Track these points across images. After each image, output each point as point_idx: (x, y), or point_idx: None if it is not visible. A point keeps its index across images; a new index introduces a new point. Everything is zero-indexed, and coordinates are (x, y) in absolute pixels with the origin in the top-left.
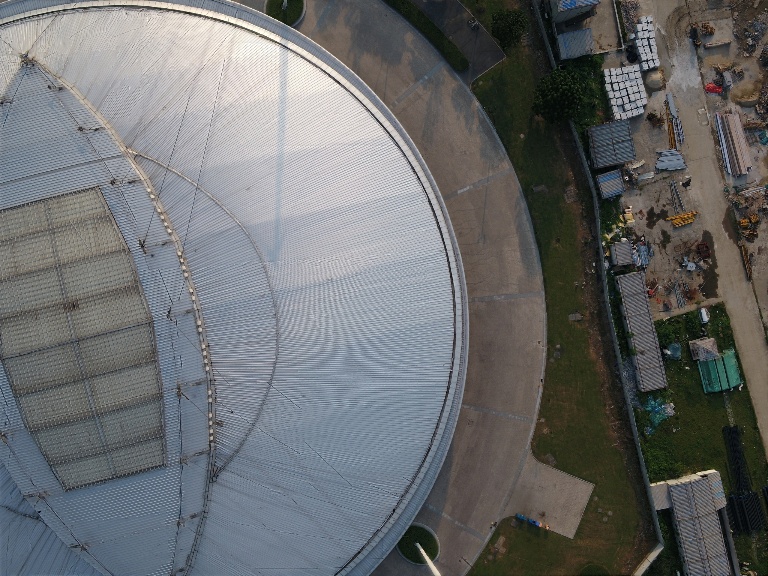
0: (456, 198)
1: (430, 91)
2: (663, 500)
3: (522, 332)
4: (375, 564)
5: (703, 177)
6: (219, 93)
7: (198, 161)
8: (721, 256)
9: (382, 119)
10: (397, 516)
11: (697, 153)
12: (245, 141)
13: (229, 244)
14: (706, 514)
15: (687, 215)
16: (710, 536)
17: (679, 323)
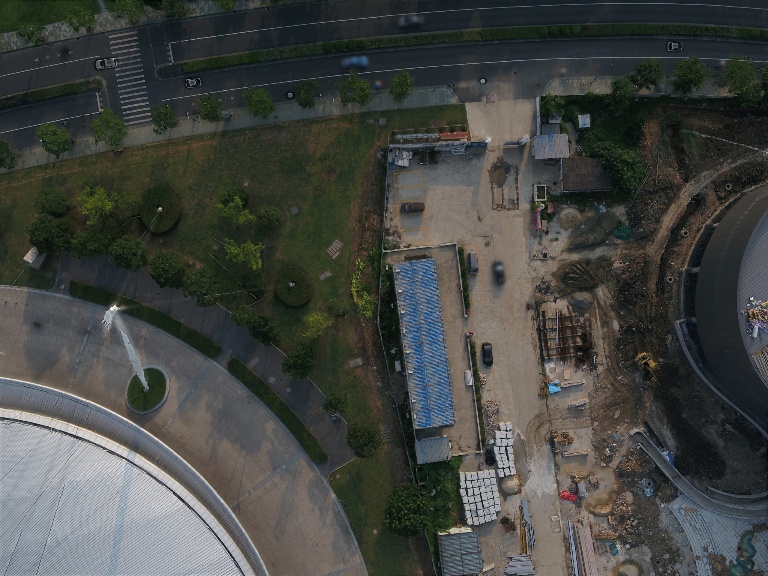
0: None
1: (287, 481)
2: None
3: None
4: None
5: None
6: (53, 526)
7: None
8: None
9: (224, 538)
10: None
11: (547, 559)
12: None
13: None
14: None
15: None
16: None
17: None
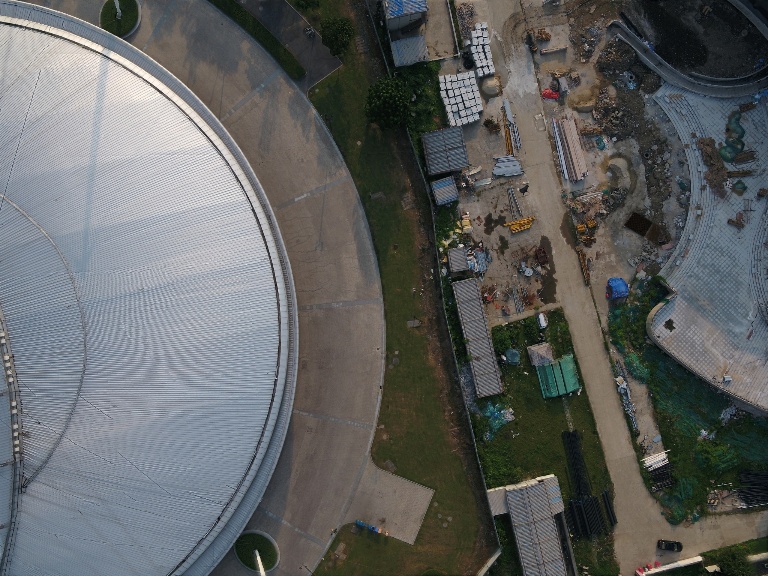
0: (293, 206)
1: (267, 99)
2: (500, 505)
3: (361, 339)
4: (206, 572)
5: (540, 183)
6: (32, 104)
7: (6, 172)
8: (559, 261)
9: (205, 128)
10: (223, 524)
11: (534, 159)
12: (56, 152)
13: (35, 255)
14: (542, 519)
15: (524, 221)
16: (546, 541)
17: (517, 328)
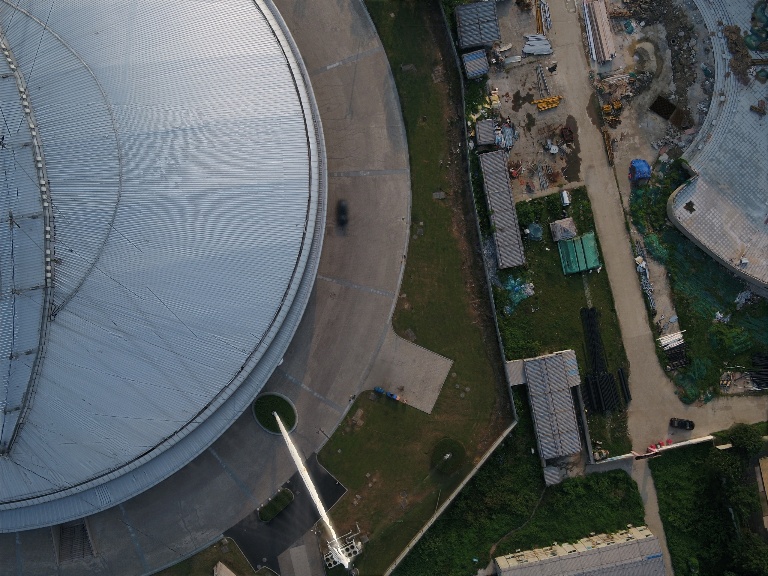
0: (325, 74)
1: None
2: (518, 376)
3: (386, 208)
4: (226, 425)
5: (569, 63)
6: None
7: (48, 3)
8: (584, 141)
9: None
10: (246, 374)
11: (564, 39)
12: None
13: (74, 84)
14: (559, 390)
15: (552, 99)
16: (562, 412)
17: (541, 204)
